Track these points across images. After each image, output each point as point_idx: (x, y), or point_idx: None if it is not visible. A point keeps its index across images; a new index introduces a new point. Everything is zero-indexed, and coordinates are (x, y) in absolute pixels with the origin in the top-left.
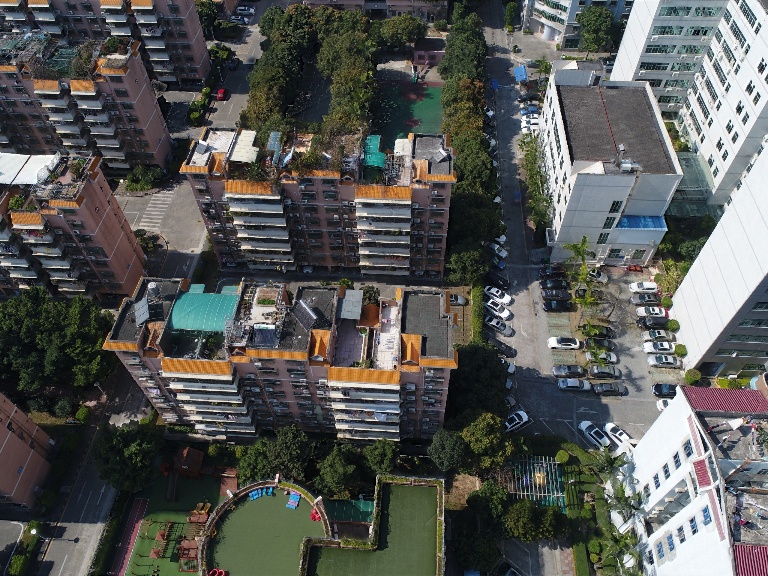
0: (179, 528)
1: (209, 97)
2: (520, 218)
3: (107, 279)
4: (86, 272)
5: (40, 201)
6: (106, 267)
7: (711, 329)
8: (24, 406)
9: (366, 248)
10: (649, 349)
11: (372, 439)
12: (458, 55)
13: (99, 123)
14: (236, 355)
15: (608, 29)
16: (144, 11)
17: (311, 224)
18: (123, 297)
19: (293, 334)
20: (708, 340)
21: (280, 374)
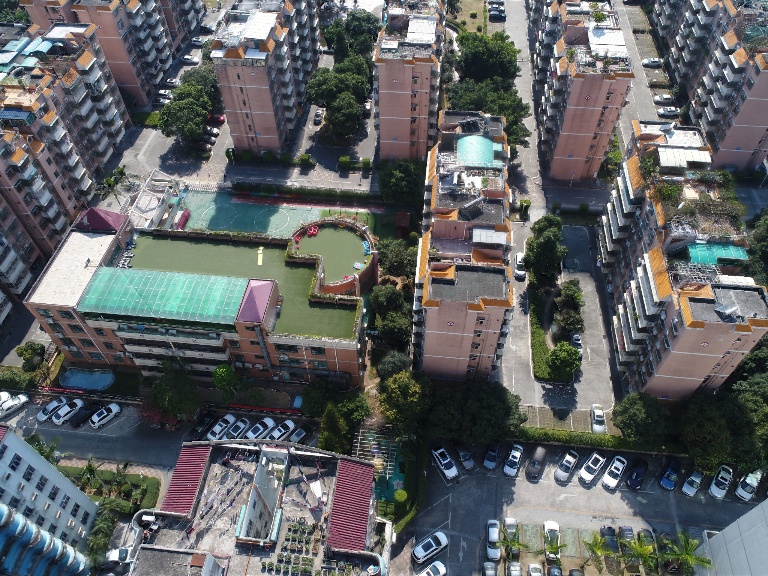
0: None
1: None
2: None
3: (553, 146)
4: None
5: None
6: (557, 136)
7: None
8: None
9: None
10: None
11: None
12: None
13: None
14: None
15: None
16: None
17: None
18: None
19: (455, 201)
20: None
21: None
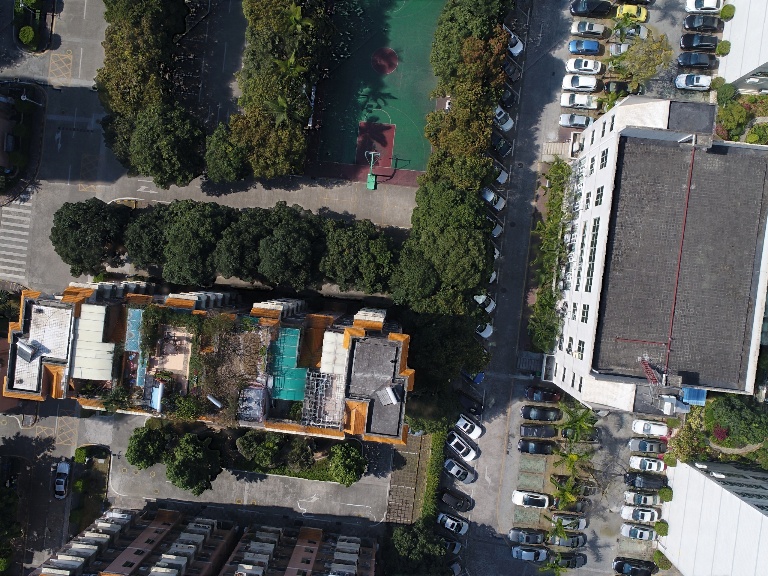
0: None
1: None
2: (520, 289)
3: None
4: None
5: None
6: None
7: (697, 573)
8: None
9: None
10: (627, 517)
11: None
12: None
13: None
14: None
15: None
16: None
17: None
18: None
19: None
20: (689, 573)
21: None
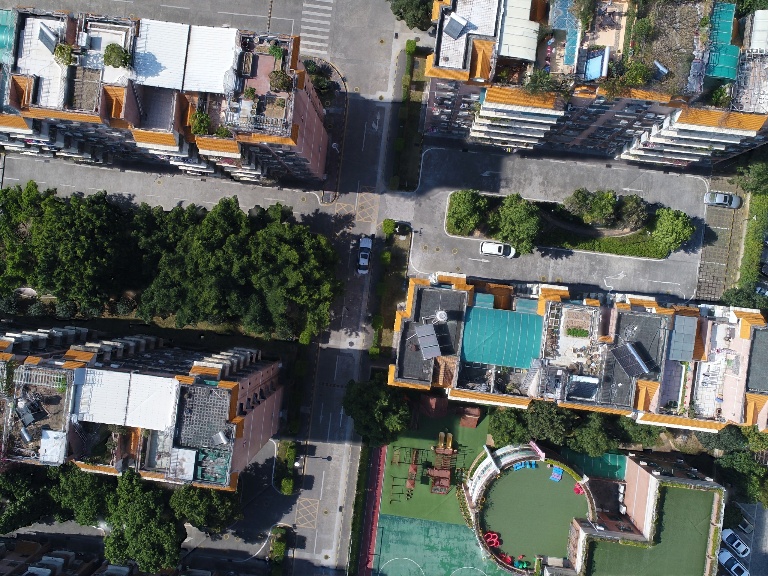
0: (424, 454)
1: None
2: None
3: (299, 171)
4: (275, 167)
5: None
6: (303, 167)
7: None
8: (235, 317)
9: None
10: None
11: None
12: None
13: None
14: None
15: None
16: None
17: None
18: None
19: (612, 380)
20: None
21: None
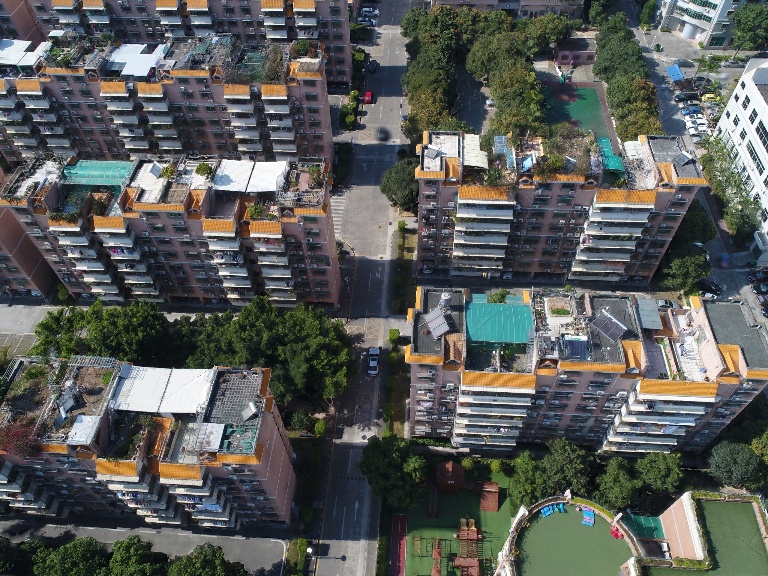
0: (447, 545)
1: (357, 100)
2: None
3: (319, 287)
4: (301, 281)
5: (281, 209)
6: (324, 275)
7: None
8: None
9: (585, 253)
10: None
11: (641, 452)
12: (620, 55)
13: (281, 128)
14: (542, 367)
15: (767, 26)
16: (306, 13)
17: (531, 229)
18: (324, 305)
19: (600, 345)
20: None
21: (577, 386)
